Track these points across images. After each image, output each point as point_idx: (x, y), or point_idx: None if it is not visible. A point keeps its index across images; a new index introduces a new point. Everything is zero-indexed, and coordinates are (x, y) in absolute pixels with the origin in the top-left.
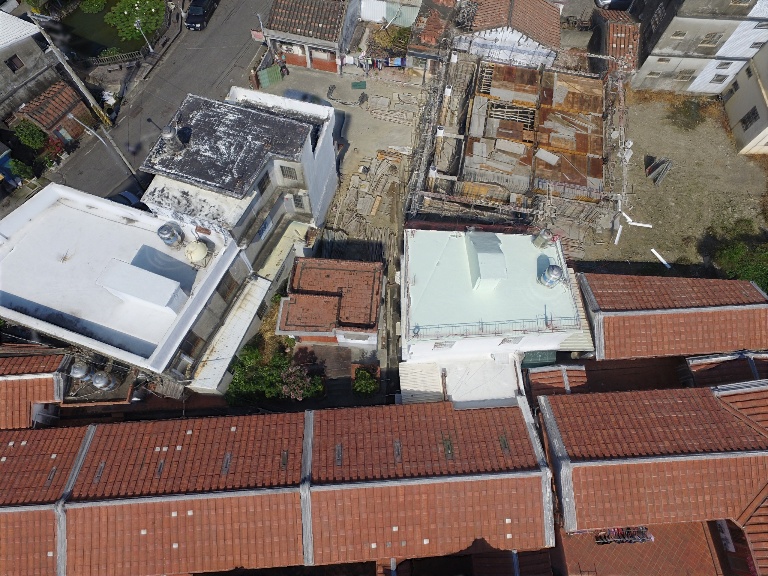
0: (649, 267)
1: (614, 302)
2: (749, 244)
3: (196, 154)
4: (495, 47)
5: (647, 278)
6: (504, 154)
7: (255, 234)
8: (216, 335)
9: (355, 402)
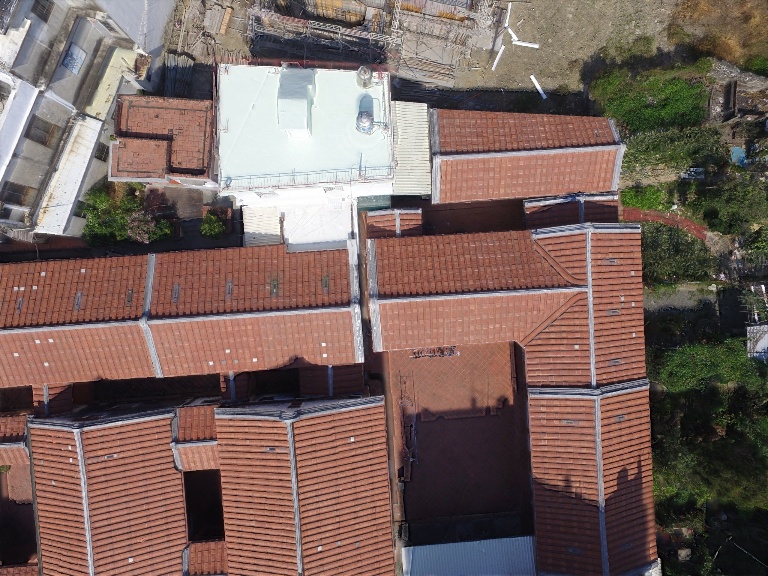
0: (523, 98)
1: (458, 143)
2: (633, 70)
3: None
4: None
5: (502, 115)
6: None
7: (53, 71)
8: (51, 181)
9: (211, 242)
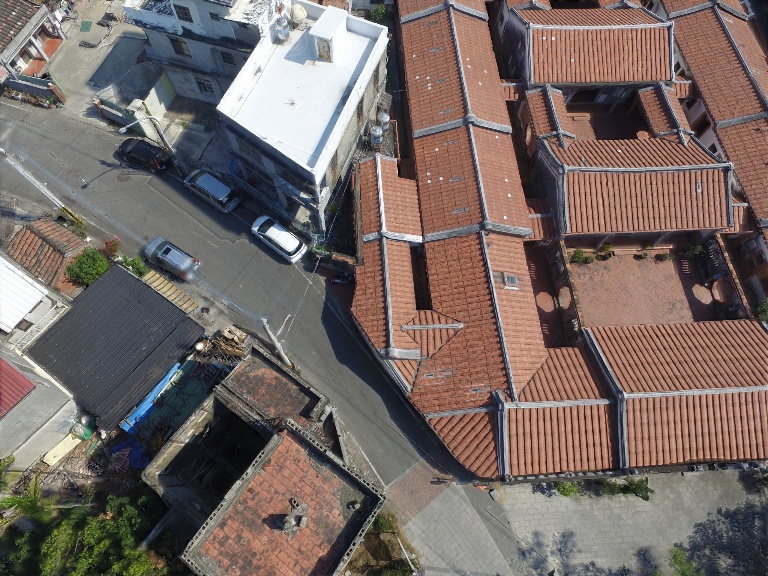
0: None
1: None
2: None
3: None
4: None
5: None
6: None
7: None
8: None
9: None
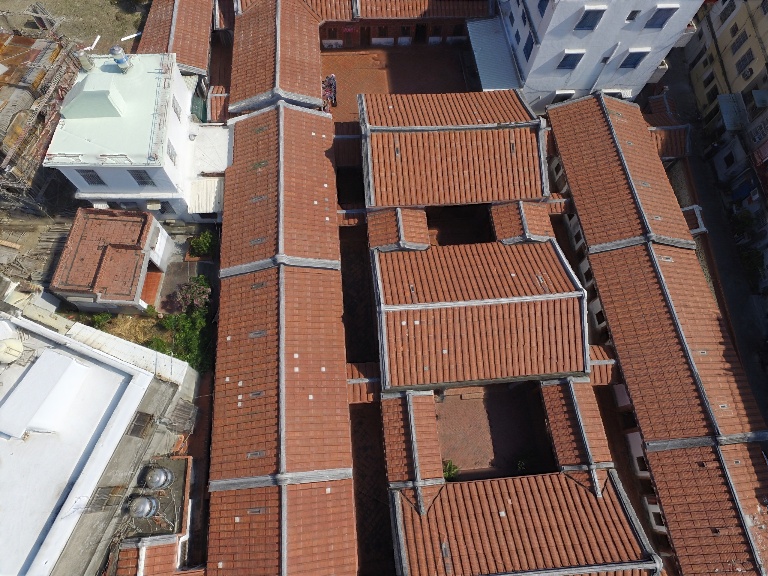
0: (137, 45)
1: None
2: None
3: None
4: None
5: (144, 34)
6: None
7: (5, 303)
8: None
9: None
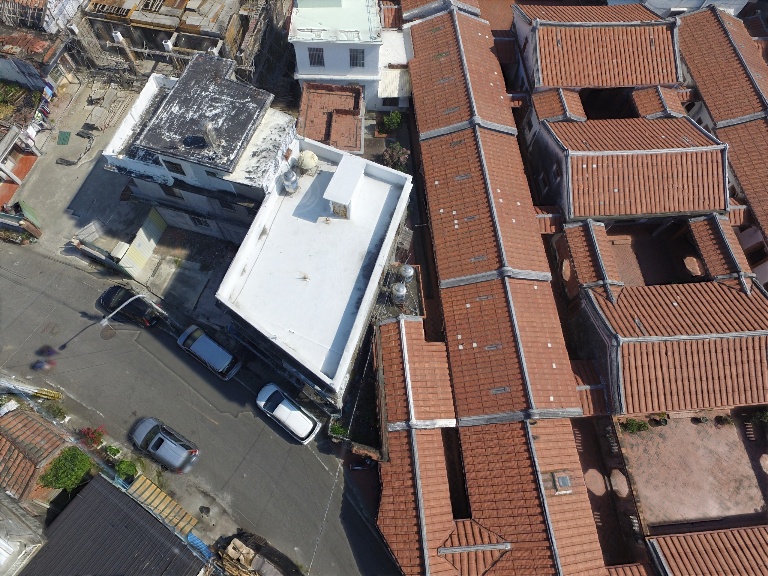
0: None
1: None
2: None
3: (220, 129)
4: (65, 4)
5: None
6: (203, 6)
7: None
8: None
9: (402, 141)
